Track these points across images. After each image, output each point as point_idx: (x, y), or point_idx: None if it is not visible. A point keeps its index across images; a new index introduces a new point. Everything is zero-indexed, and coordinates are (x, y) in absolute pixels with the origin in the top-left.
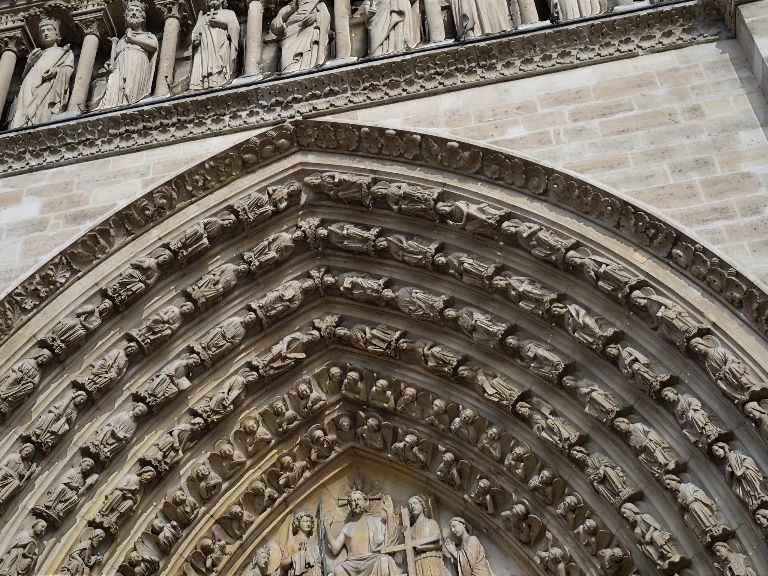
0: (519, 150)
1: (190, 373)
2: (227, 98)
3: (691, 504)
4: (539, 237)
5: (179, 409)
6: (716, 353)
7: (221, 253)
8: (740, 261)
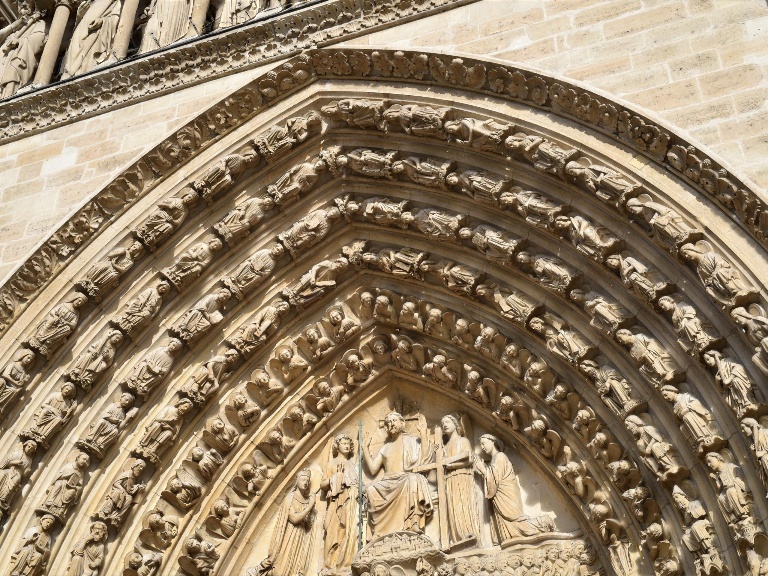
0: (521, 61)
1: (224, 307)
2: (246, 34)
3: (685, 415)
4: (540, 150)
5: (215, 342)
6: (706, 259)
7: (247, 188)
8: (731, 161)
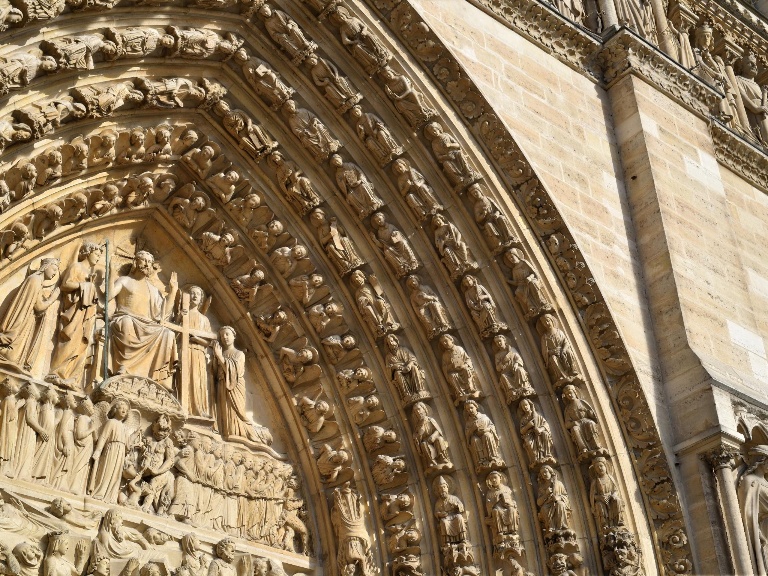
0: (471, 72)
1: None
2: None
3: (487, 432)
4: (461, 155)
5: (67, 83)
6: (559, 334)
7: None
8: (598, 276)
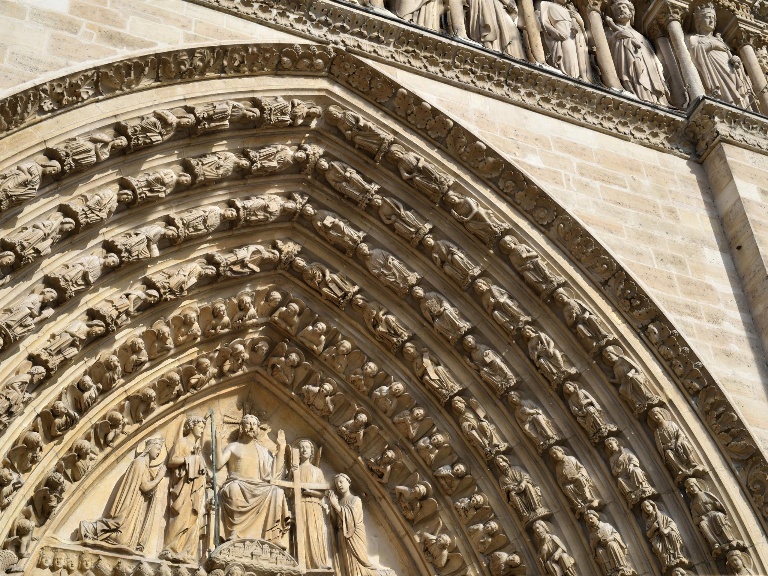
0: (537, 178)
1: (157, 242)
2: None
3: (610, 542)
4: (538, 263)
5: (137, 273)
6: (671, 426)
7: (228, 139)
8: (706, 359)
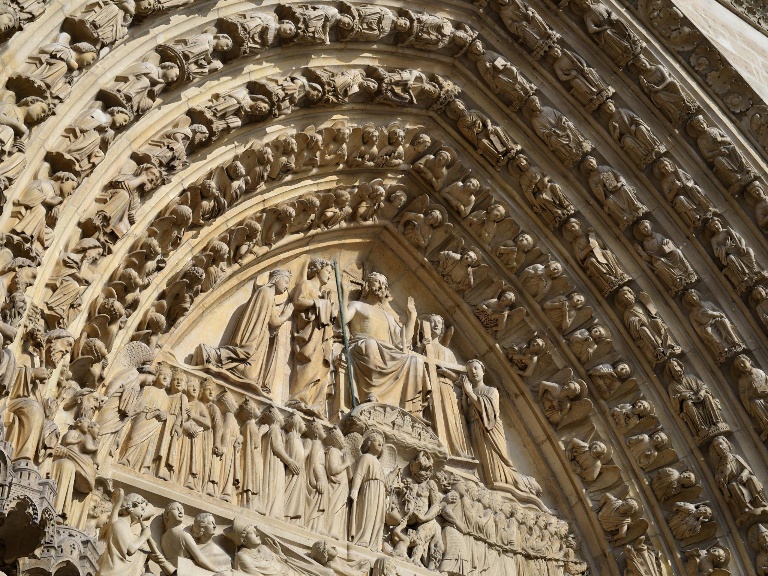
0: (733, 61)
1: None
2: None
3: None
4: (735, 149)
5: (300, 60)
6: None
7: None
8: None
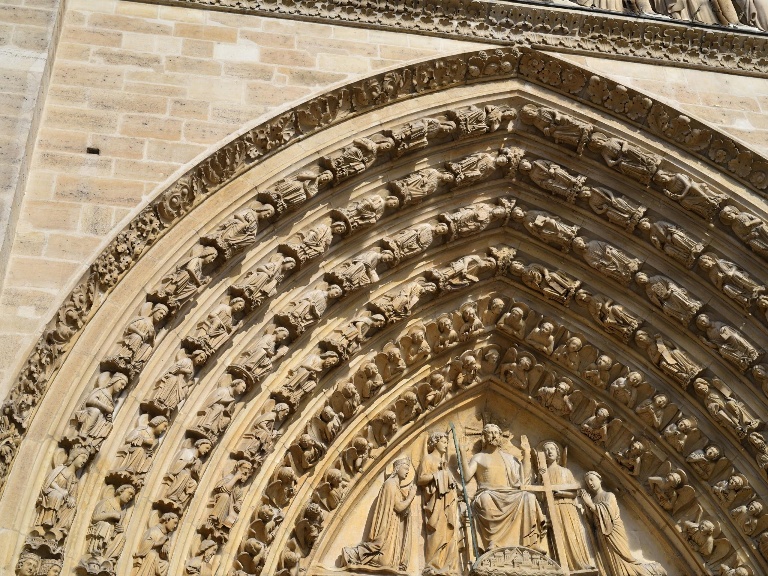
0: (749, 143)
1: (375, 267)
2: (459, 3)
3: None
4: (764, 230)
5: (360, 301)
6: None
7: (428, 156)
8: None
